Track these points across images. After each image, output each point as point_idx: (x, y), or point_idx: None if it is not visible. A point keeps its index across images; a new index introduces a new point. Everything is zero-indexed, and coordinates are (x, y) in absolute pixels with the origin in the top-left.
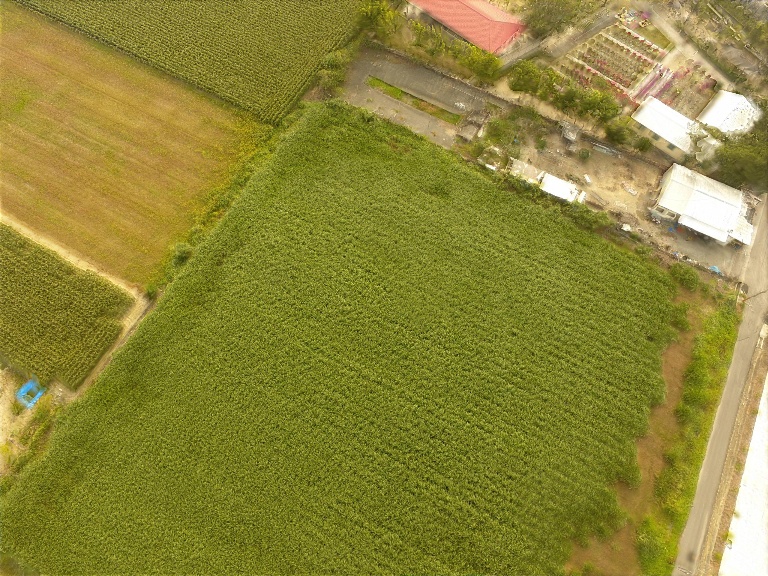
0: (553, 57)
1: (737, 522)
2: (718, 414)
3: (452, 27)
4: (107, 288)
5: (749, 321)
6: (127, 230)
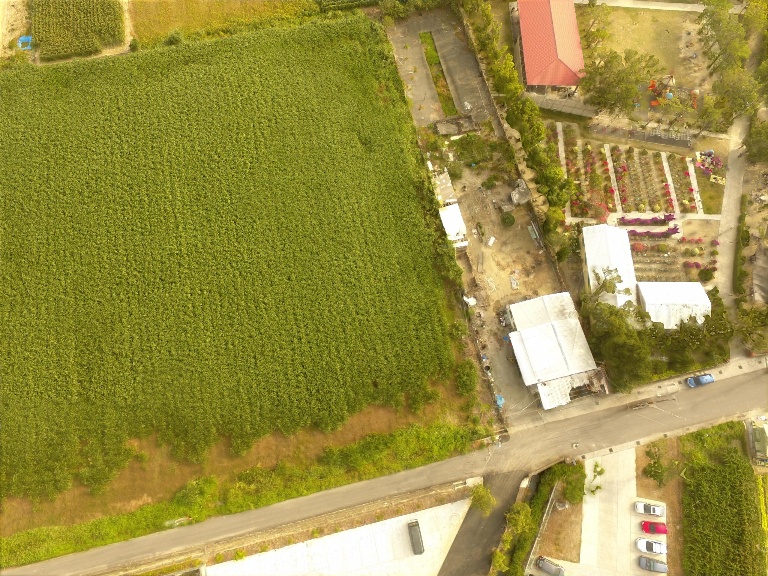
0: (592, 136)
1: (269, 557)
2: (356, 485)
3: (525, 41)
4: (115, 21)
5: (472, 461)
6: (167, 0)
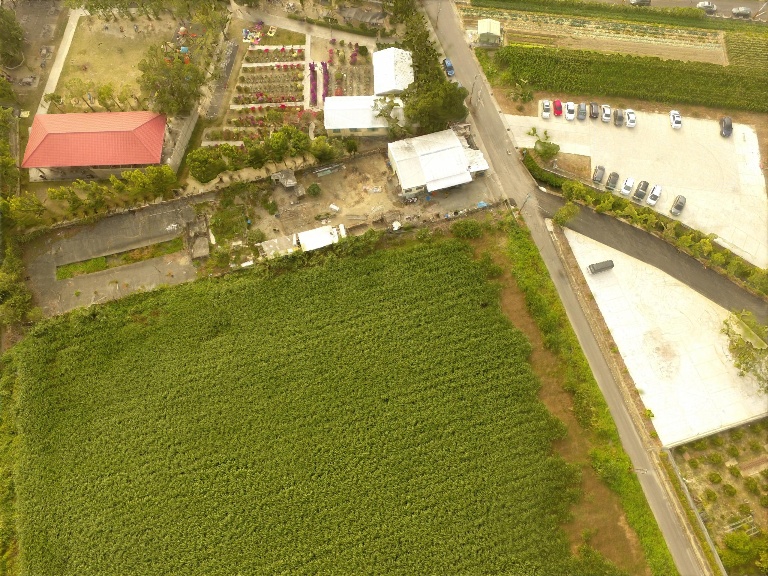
0: (220, 118)
1: (642, 389)
2: (570, 319)
3: (100, 162)
4: None
5: (534, 226)
6: None
